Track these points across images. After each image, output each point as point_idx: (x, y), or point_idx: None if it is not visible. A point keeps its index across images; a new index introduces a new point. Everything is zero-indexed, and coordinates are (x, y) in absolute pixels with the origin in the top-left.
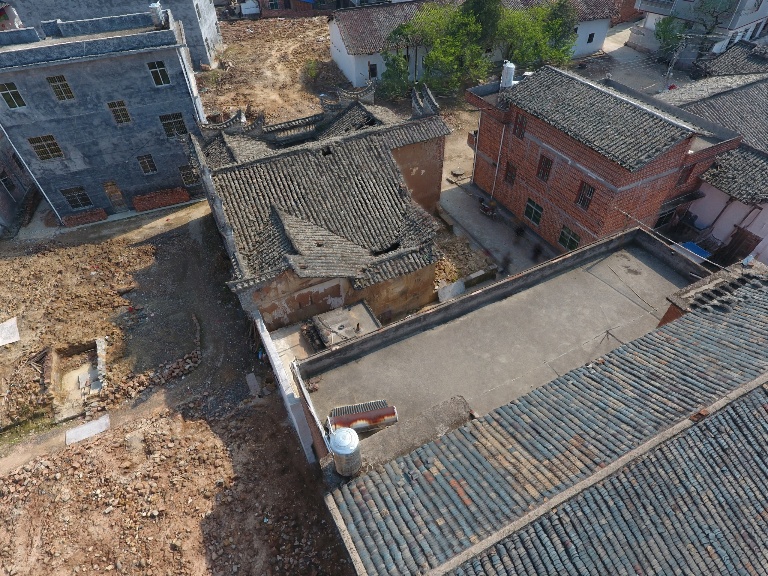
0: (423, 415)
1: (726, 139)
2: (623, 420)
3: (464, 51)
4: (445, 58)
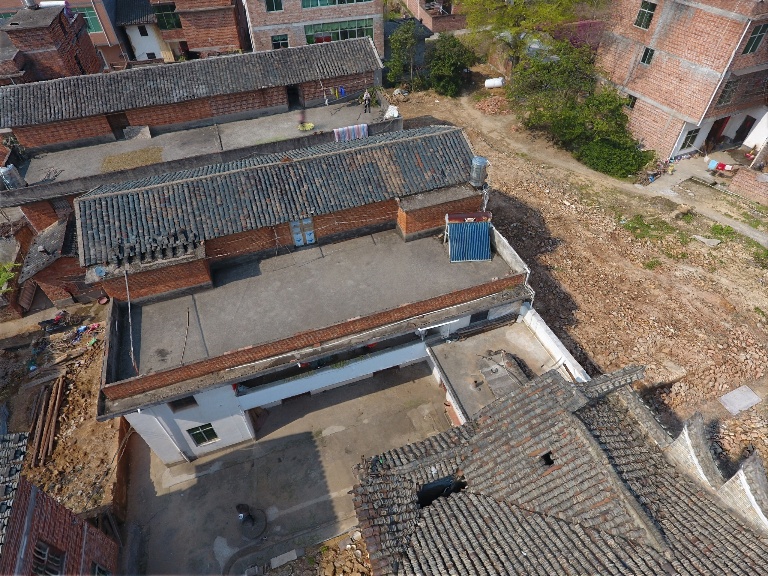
0: (431, 203)
1: None
2: None
3: None
4: None
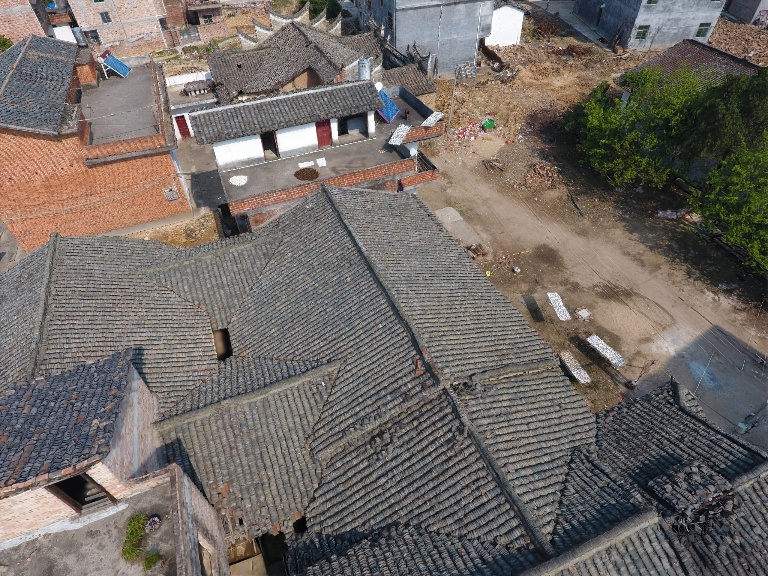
0: (88, 56)
1: (245, 207)
2: None
3: None
4: None
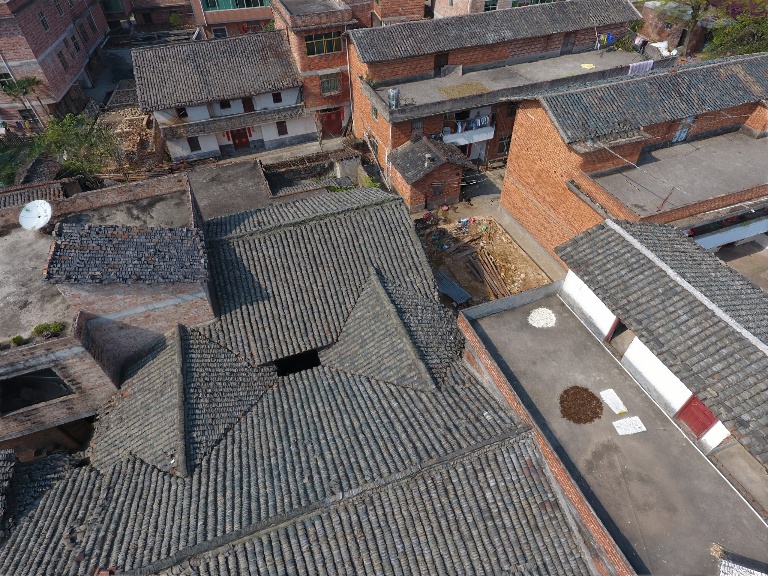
0: None
1: None
2: None
3: None
4: None
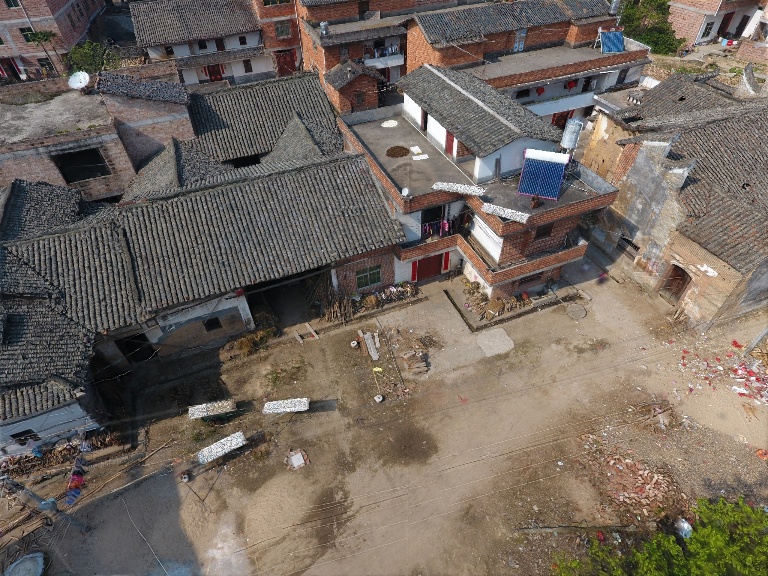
0: None
1: None
2: (531, 7)
3: None
4: (726, 521)
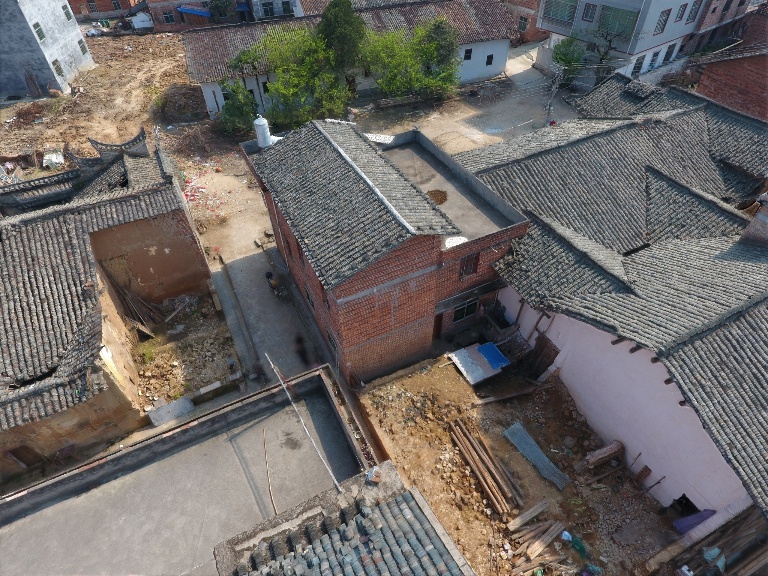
0: None
1: (515, 222)
2: None
3: (313, 81)
4: (286, 90)
